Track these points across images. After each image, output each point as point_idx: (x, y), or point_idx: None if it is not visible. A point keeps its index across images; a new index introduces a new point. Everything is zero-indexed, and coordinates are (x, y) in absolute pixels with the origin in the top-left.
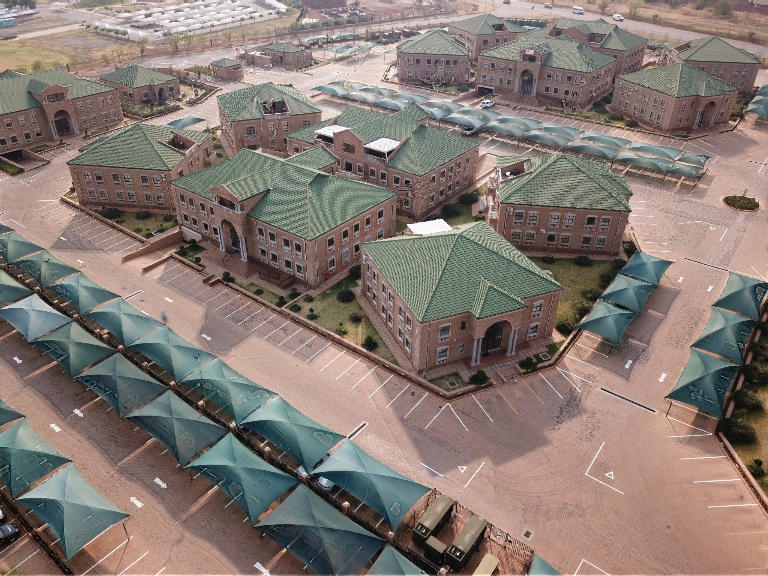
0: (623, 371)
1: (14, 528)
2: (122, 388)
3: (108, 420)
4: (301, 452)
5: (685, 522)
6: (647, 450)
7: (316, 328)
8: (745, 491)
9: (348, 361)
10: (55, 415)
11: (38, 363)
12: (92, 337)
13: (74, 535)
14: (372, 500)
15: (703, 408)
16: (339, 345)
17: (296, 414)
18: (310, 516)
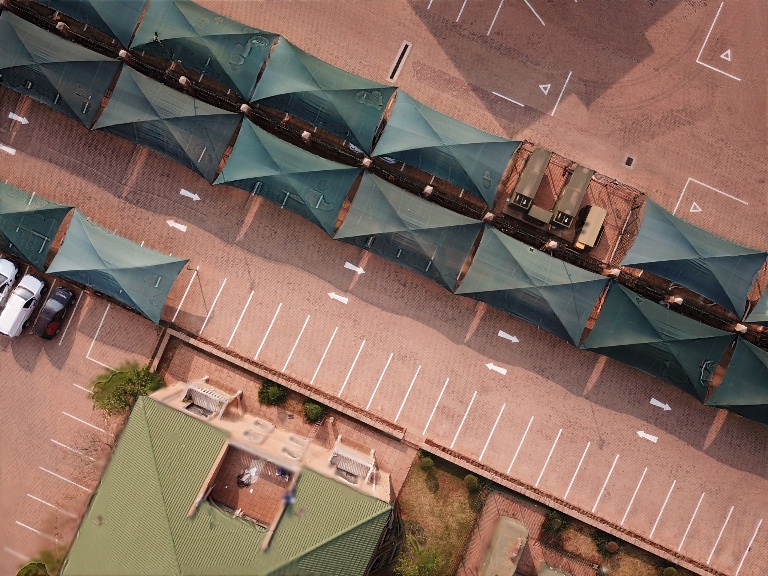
0: None
1: (66, 292)
2: (60, 83)
3: (66, 121)
4: (352, 132)
5: None
6: None
7: None
8: None
9: None
10: None
11: None
12: None
13: (146, 301)
14: (458, 178)
15: None
16: None
17: (321, 70)
18: (396, 219)
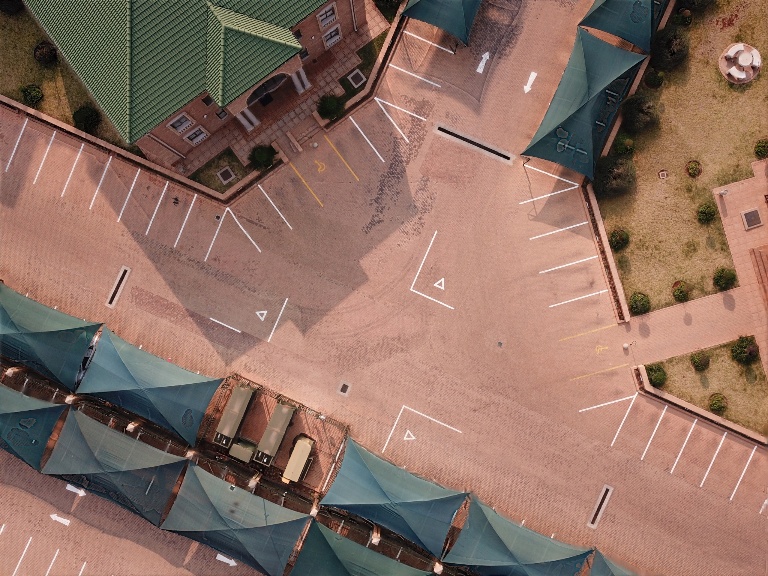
0: (473, 82)
1: None
2: None
3: None
4: None
5: (519, 334)
6: (490, 233)
7: None
8: (598, 273)
9: (66, 155)
10: None
11: None
12: None
13: None
14: (157, 418)
15: (570, 166)
16: (41, 123)
17: (22, 311)
18: (93, 461)
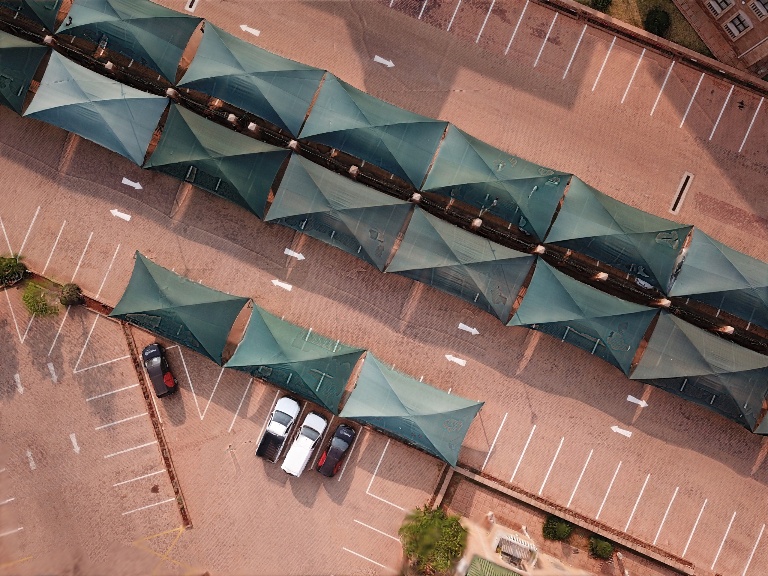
0: None
1: (349, 430)
2: (357, 229)
3: (343, 256)
4: (654, 274)
5: None
6: None
7: (557, 1)
8: None
9: (628, 60)
10: (266, 266)
11: (167, 182)
12: (231, 132)
13: (446, 445)
14: (761, 319)
15: None
16: (604, 29)
17: (621, 212)
18: (701, 362)
